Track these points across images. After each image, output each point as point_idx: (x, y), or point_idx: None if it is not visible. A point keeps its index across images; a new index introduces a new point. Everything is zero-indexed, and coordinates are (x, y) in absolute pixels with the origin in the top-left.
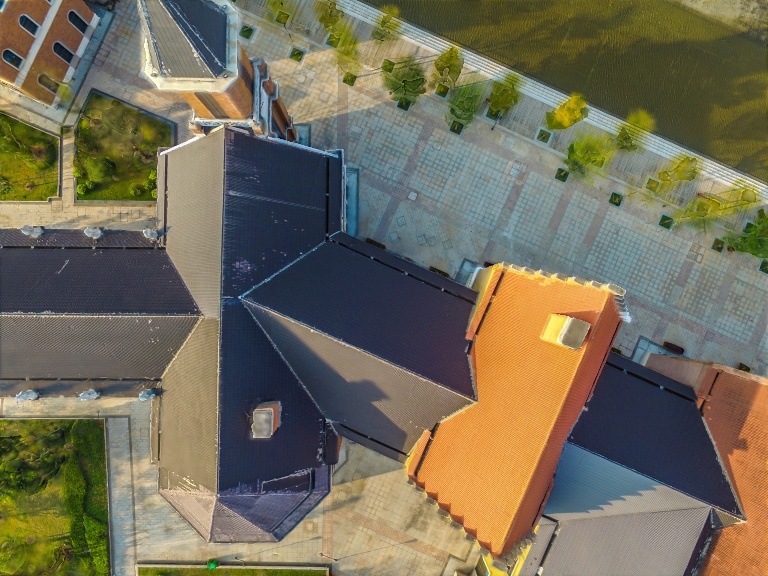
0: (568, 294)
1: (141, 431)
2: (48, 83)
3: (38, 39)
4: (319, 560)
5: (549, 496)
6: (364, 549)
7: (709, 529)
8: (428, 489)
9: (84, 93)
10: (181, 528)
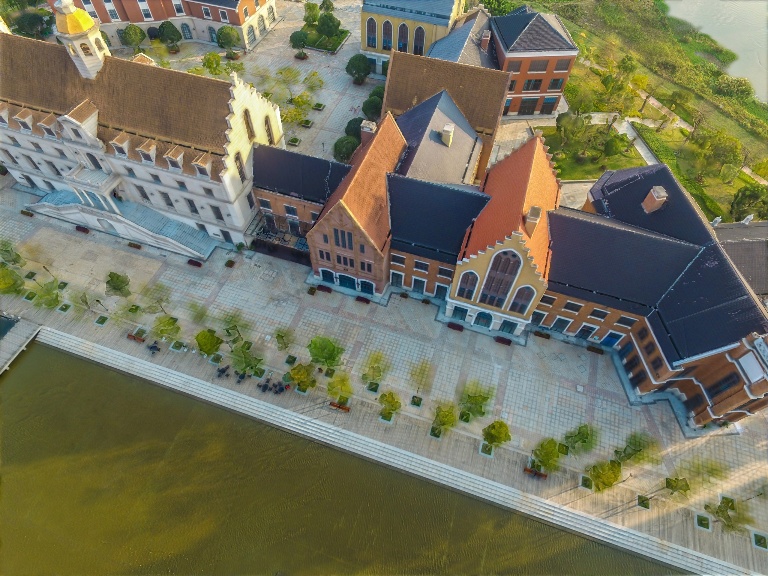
0: (527, 246)
1: None
2: None
3: None
4: None
5: (480, 186)
6: None
7: (399, 172)
8: None
9: None
10: None
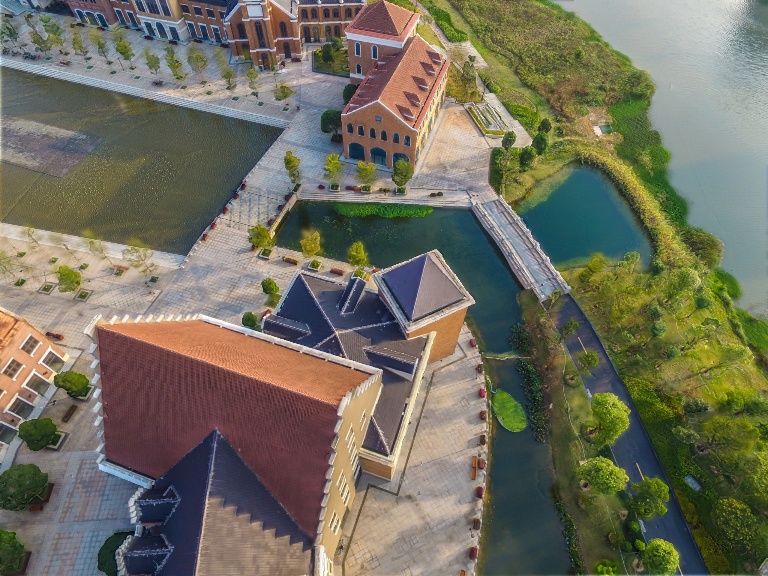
0: None
1: None
2: None
3: None
4: None
5: None
6: None
7: None
8: None
9: None
10: None
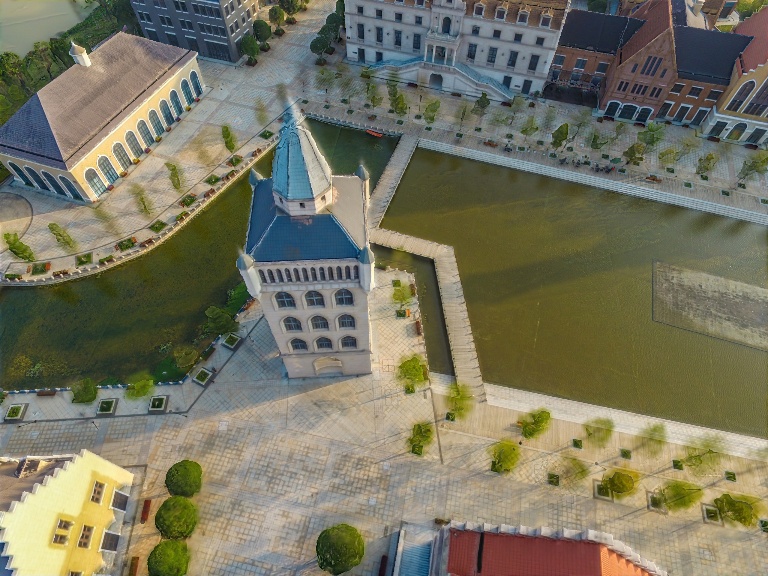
0: None
1: None
2: None
3: None
4: None
5: None
6: None
7: None
8: None
9: None
10: None
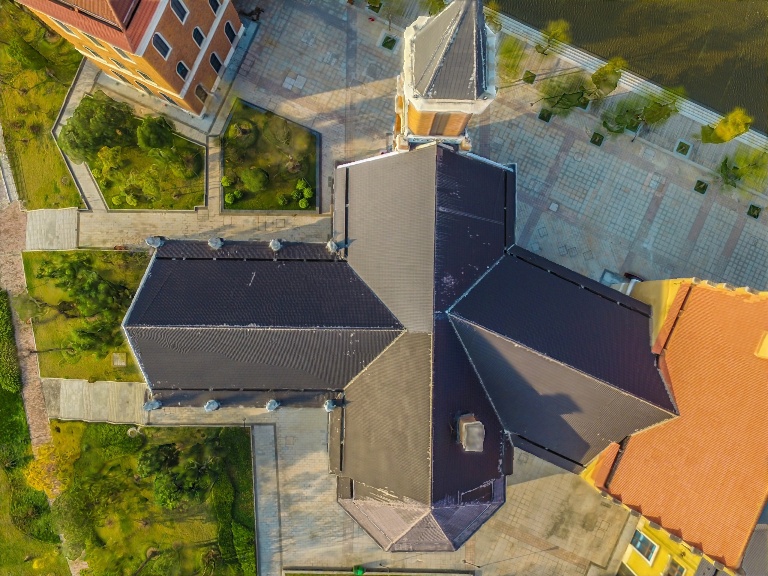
0: None
1: (286, 439)
2: (200, 93)
3: (202, 50)
4: (462, 567)
5: None
6: (506, 556)
7: None
8: (627, 501)
9: (229, 103)
10: (326, 535)
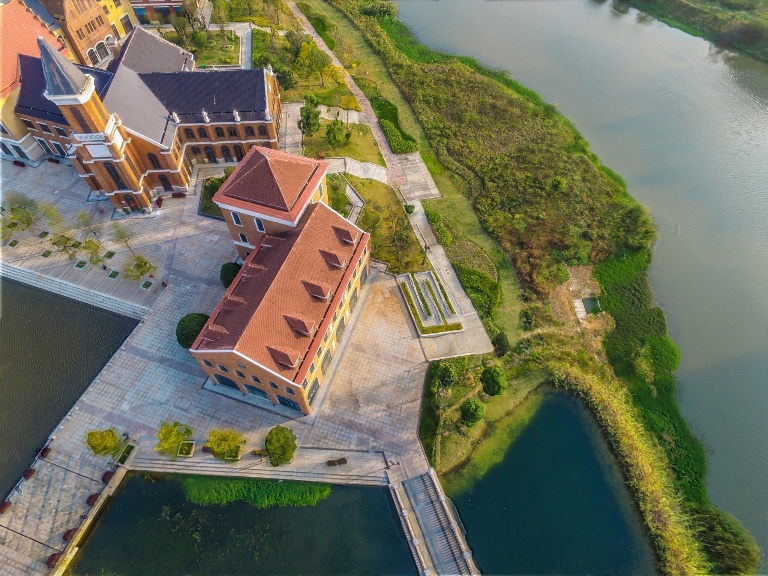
0: None
1: None
2: None
3: None
4: None
5: None
6: None
7: None
8: None
9: None
10: None
